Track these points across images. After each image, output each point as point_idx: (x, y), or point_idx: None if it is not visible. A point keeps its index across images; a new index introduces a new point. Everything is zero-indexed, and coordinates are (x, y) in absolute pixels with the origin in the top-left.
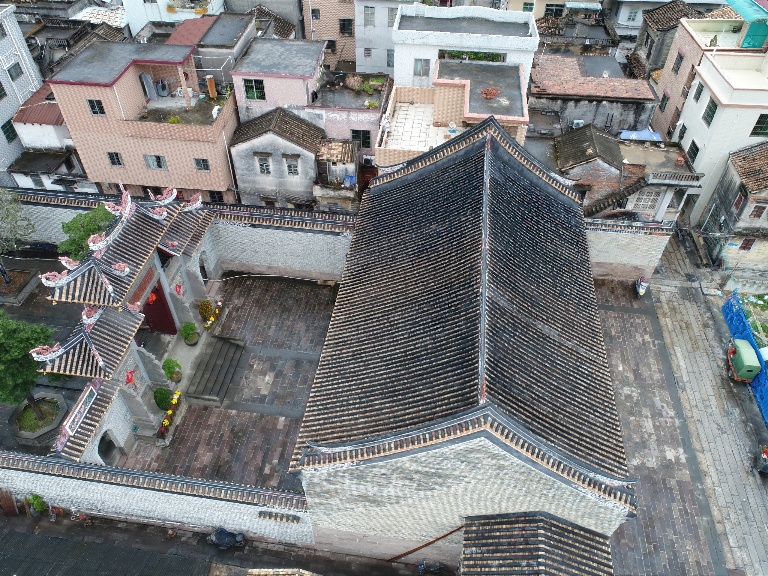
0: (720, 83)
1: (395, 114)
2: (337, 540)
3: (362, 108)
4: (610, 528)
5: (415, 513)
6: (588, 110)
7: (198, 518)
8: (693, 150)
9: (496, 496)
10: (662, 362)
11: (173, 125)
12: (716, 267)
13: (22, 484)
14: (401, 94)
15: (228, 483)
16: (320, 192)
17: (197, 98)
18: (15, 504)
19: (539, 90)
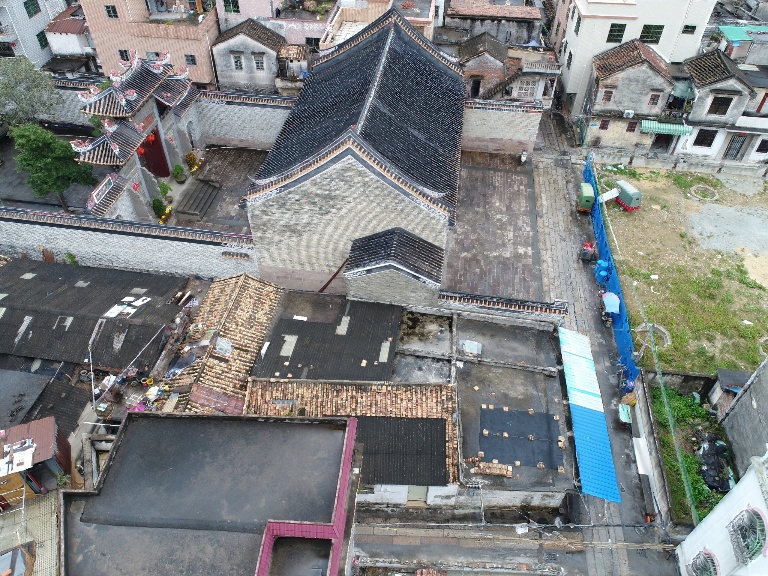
0: (582, 1)
1: (341, 28)
2: (276, 279)
3: (313, 20)
4: (442, 240)
5: (322, 241)
6: (492, 28)
7: (182, 267)
8: (570, 58)
9: (368, 215)
10: (529, 201)
11: (169, 26)
12: (585, 146)
13: (62, 243)
14: (346, 14)
15: None
16: (281, 84)
17: (188, 13)
18: None
19: (453, 12)
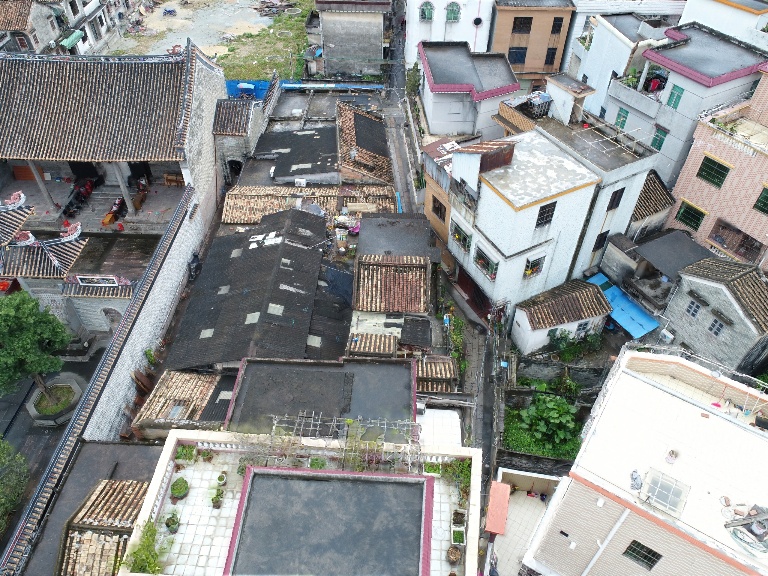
0: None
1: None
2: None
3: None
4: None
5: None
6: None
7: None
8: None
9: None
10: None
11: None
12: None
13: (138, 347)
14: None
15: None
16: None
17: None
18: (146, 377)
19: None
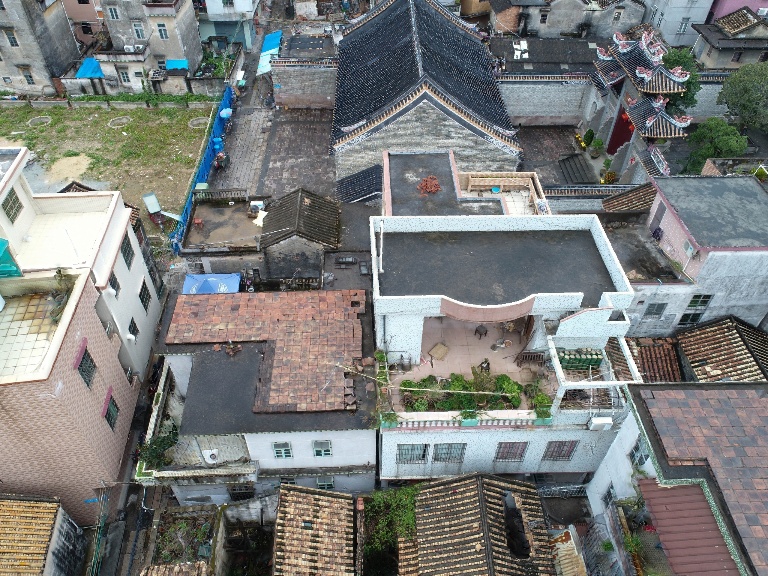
0: None
1: None
2: None
3: None
4: None
5: None
6: None
7: None
8: None
9: None
10: None
11: None
12: None
13: None
14: None
15: (515, 78)
16: None
17: None
18: None
19: (353, 296)
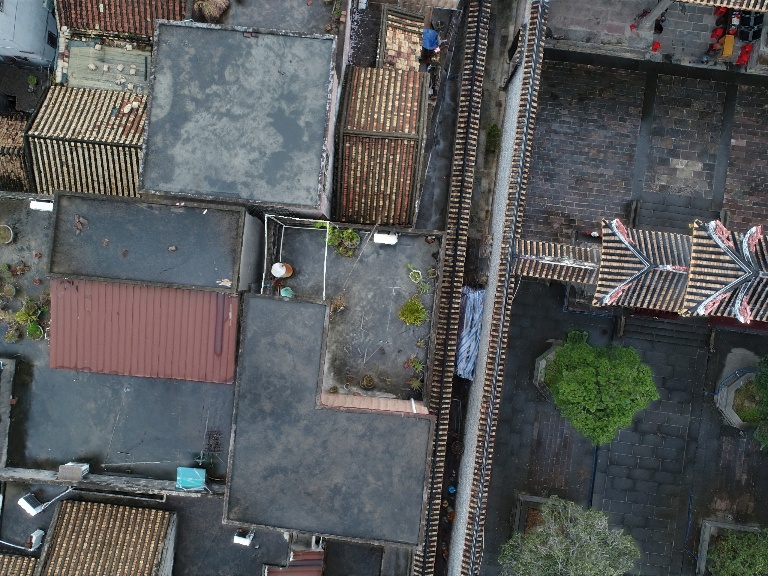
0: None
1: None
2: None
3: None
4: None
5: None
6: None
7: None
8: None
9: None
10: None
11: None
12: None
13: None
14: None
15: None
16: None
17: None
18: None
19: None
